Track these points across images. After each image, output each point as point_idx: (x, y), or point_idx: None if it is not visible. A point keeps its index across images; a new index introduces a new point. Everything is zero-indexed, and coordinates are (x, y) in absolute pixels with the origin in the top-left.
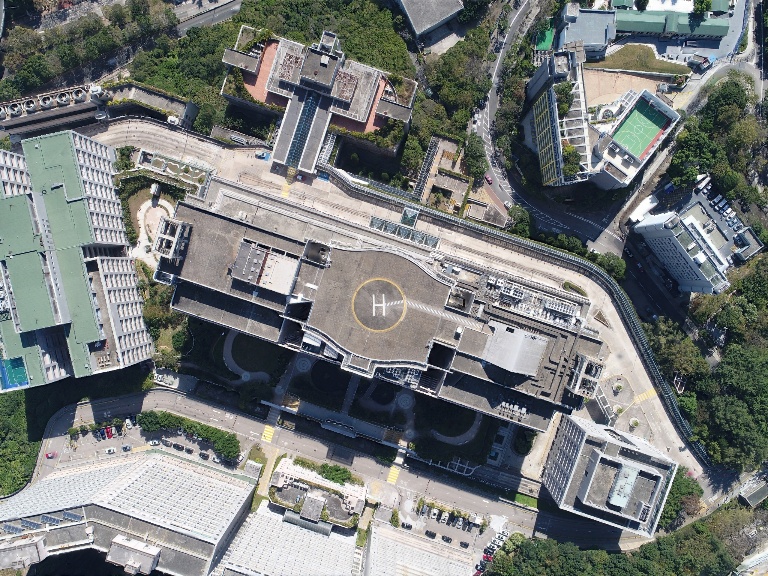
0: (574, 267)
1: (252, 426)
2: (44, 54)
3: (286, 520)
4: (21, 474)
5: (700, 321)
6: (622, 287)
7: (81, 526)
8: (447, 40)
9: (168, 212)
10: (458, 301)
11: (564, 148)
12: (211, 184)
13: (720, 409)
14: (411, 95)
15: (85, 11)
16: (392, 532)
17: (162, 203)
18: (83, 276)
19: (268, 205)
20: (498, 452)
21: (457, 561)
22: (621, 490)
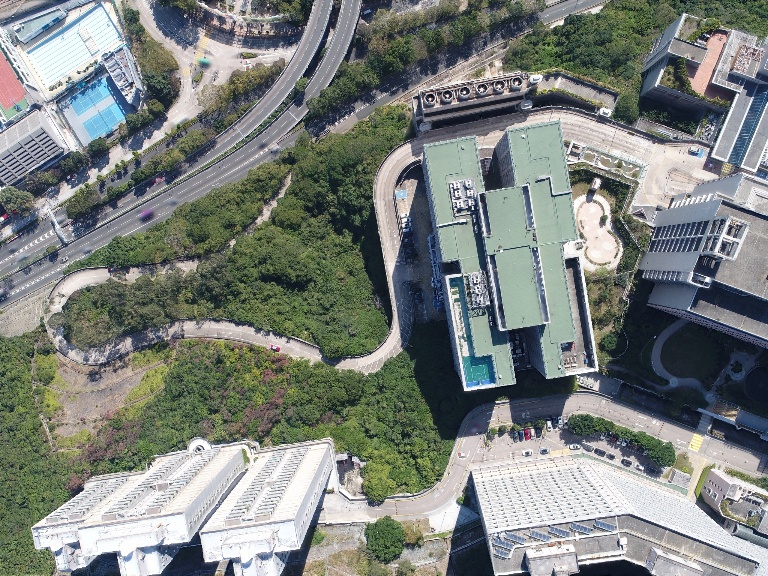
0: None
1: (679, 434)
2: None
3: (737, 534)
4: (435, 473)
5: None
6: None
7: (612, 536)
8: None
9: (603, 208)
10: None
11: None
12: (742, 182)
13: None
14: None
15: None
16: None
17: (597, 198)
18: (563, 273)
19: None
20: None
21: None
22: None
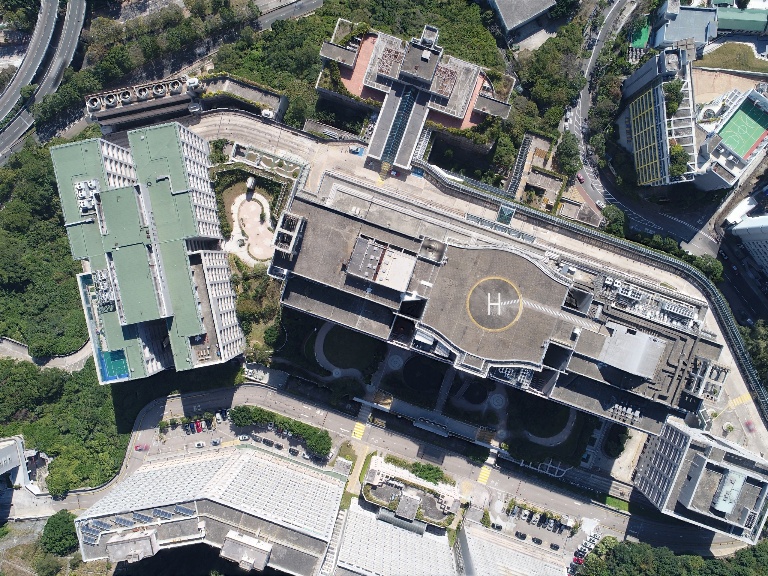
0: (671, 268)
1: (343, 423)
2: (125, 45)
3: (380, 518)
4: (110, 466)
5: None
6: (718, 290)
7: (193, 520)
8: (536, 36)
9: (262, 206)
10: (572, 301)
11: (672, 148)
12: (324, 179)
13: None
14: (509, 91)
15: (165, 2)
16: (484, 532)
17: (256, 197)
18: (186, 269)
19: (382, 201)
20: (590, 454)
21: (551, 563)
22: (727, 496)
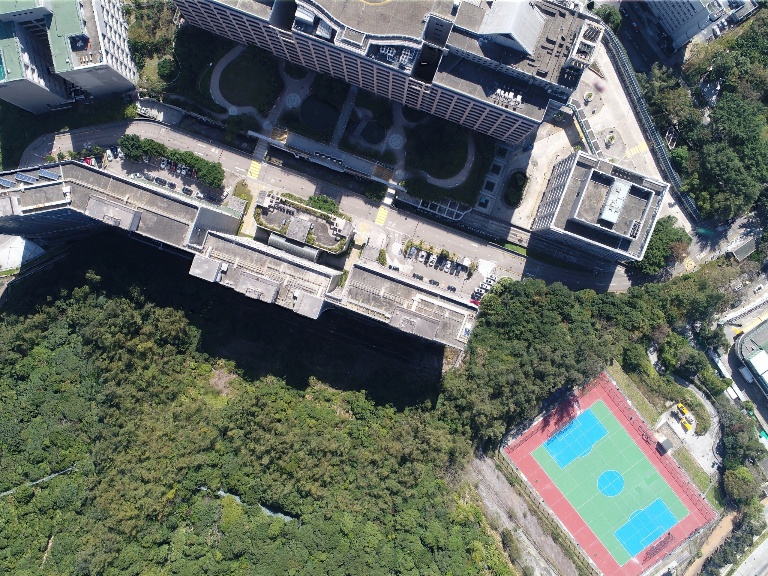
0: None
1: (238, 161)
2: None
3: (271, 244)
4: None
5: (693, 81)
6: None
7: (58, 186)
8: None
9: None
10: None
11: None
12: None
13: (711, 154)
14: None
15: None
16: (379, 268)
17: None
18: None
19: None
20: (488, 199)
21: None
22: (613, 204)
